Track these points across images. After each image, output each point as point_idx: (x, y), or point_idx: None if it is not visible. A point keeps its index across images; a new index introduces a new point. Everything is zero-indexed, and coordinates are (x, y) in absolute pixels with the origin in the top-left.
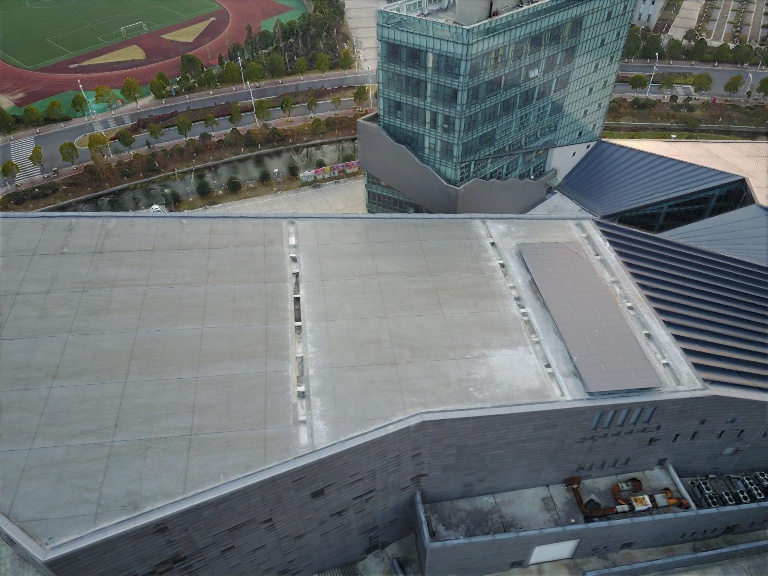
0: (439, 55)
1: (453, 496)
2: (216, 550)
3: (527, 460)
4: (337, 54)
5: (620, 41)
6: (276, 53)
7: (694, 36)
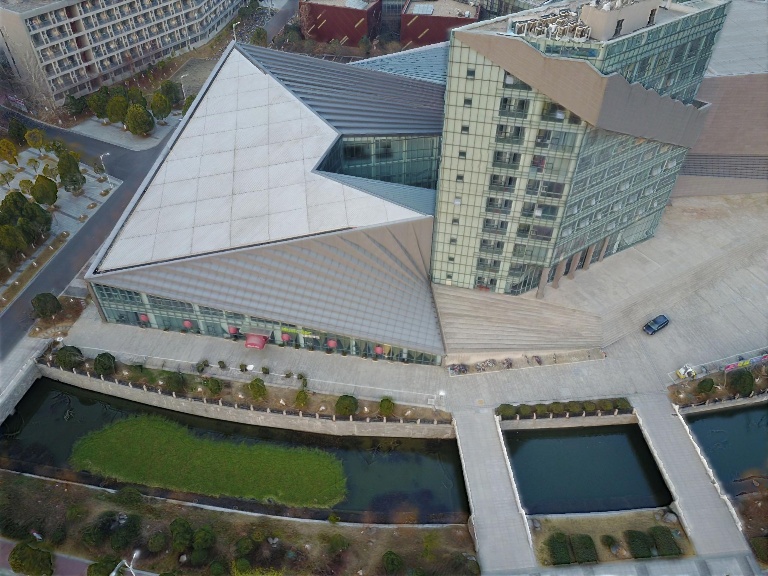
0: None
1: None
2: None
3: None
4: None
5: None
6: None
7: None
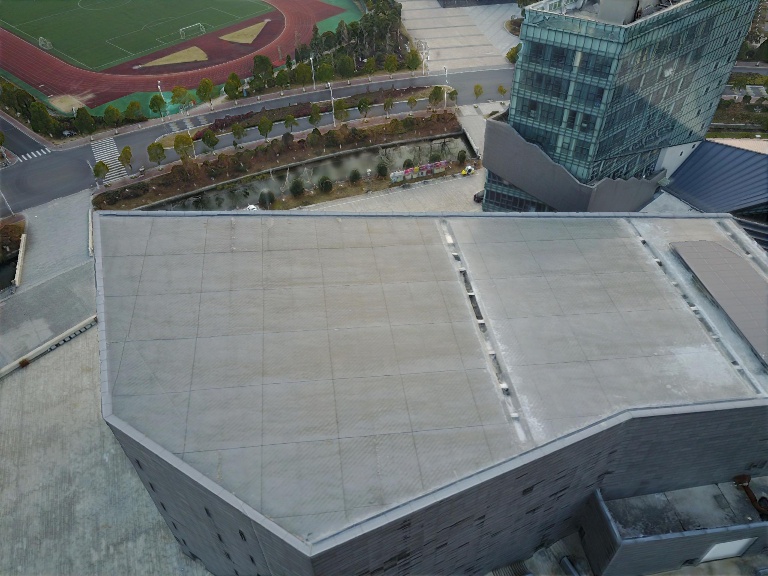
0: (589, 54)
1: (626, 494)
2: (432, 547)
3: (709, 458)
4: (401, 55)
5: (739, 41)
6: (341, 54)
7: (755, 37)
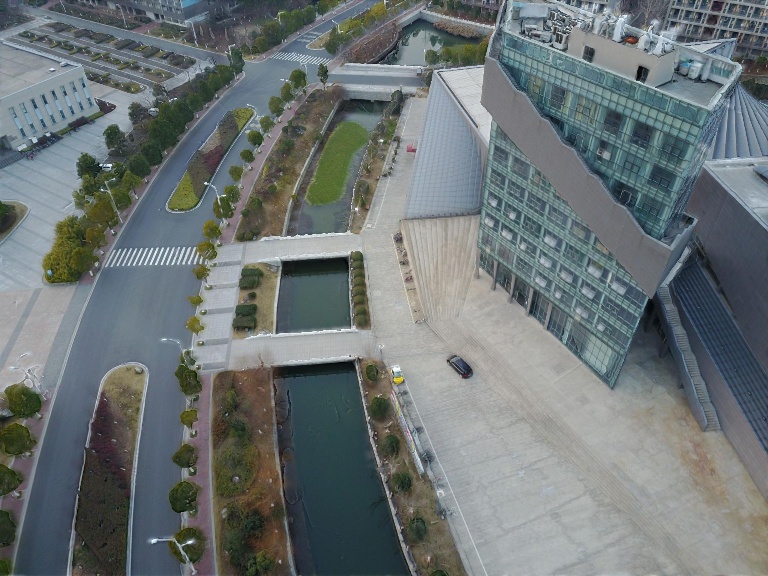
0: None
1: None
2: None
3: None
4: None
5: None
6: None
7: (160, 89)
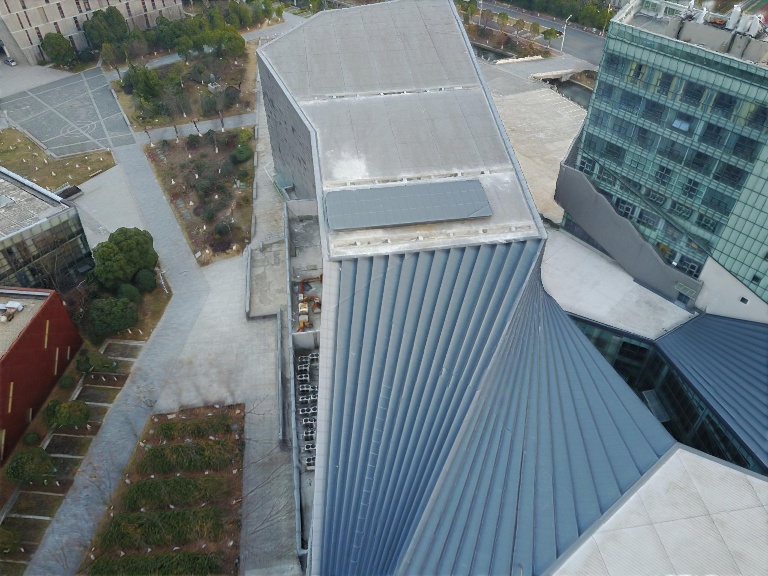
0: None
1: None
2: None
3: None
4: None
5: None
6: None
7: None
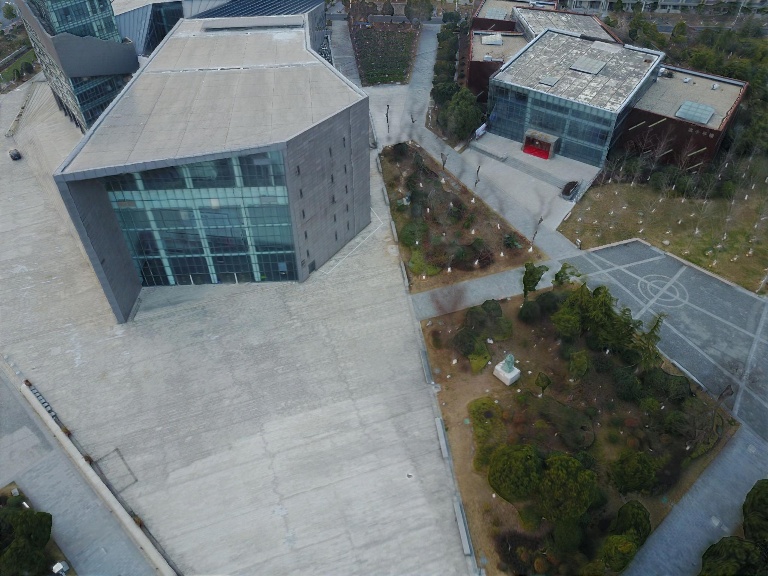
0: None
1: None
2: None
3: None
4: None
5: None
6: None
7: None
